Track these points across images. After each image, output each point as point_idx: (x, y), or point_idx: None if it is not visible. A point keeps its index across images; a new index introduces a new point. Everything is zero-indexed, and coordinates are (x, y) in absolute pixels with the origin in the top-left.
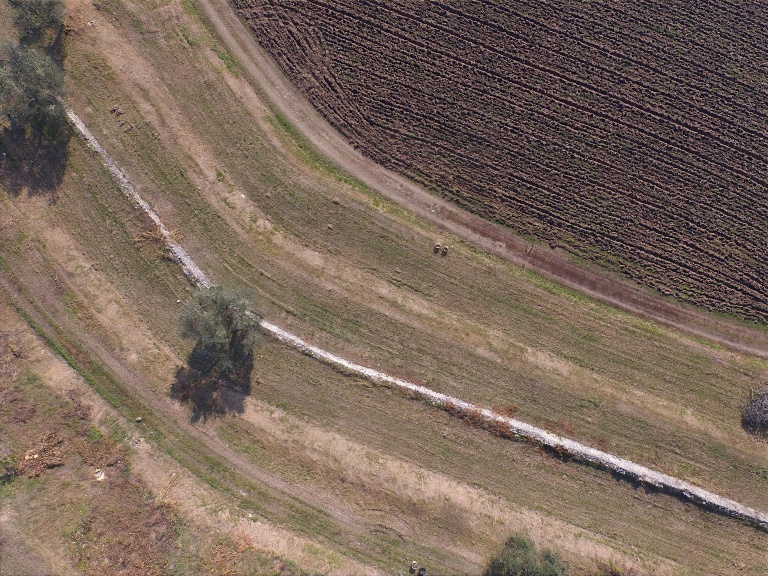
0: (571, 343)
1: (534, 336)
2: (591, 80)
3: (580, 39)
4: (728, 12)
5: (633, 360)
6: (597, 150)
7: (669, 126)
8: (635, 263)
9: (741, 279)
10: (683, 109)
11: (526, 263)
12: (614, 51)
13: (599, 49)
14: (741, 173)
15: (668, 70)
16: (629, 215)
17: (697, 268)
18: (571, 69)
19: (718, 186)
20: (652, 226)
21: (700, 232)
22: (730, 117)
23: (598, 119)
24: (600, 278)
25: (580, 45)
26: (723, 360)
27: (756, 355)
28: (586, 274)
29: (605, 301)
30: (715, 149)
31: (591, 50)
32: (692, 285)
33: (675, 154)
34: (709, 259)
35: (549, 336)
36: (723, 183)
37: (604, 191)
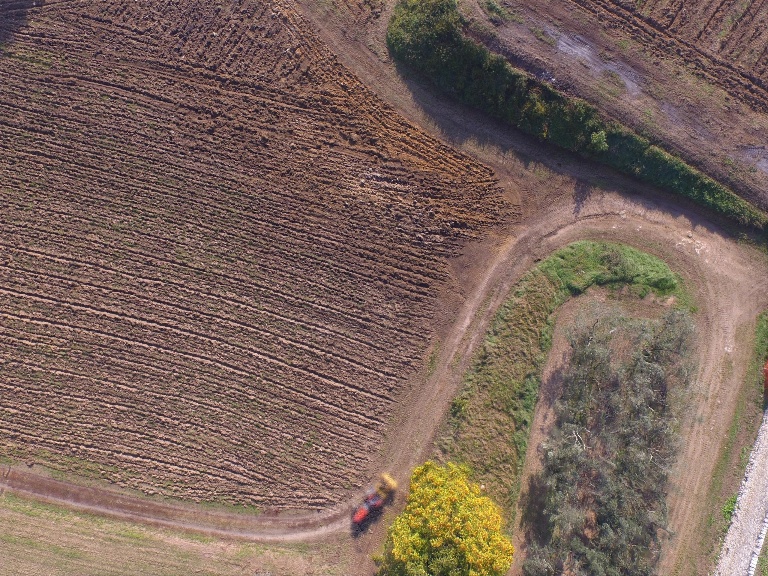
0: (53, 565)
1: (13, 565)
2: (42, 289)
3: (25, 249)
4: (171, 195)
5: (119, 571)
6: (58, 359)
7: (126, 323)
8: (115, 467)
9: (221, 466)
10: (138, 303)
11: (5, 487)
12: (61, 255)
13: (47, 255)
14: (205, 358)
15: (118, 265)
16: (101, 420)
17: (176, 462)
18: (20, 281)
19: (184, 375)
20: (125, 427)
21: (173, 425)
22: (185, 303)
23: (54, 328)
24: (83, 488)
25: (27, 255)
26: (212, 554)
27: (250, 540)
28: (68, 487)
29: (91, 511)
30: (175, 338)
31: (38, 258)
32: (175, 480)
33: (136, 350)
34: (187, 451)
35: (29, 562)
36: (188, 372)
37: (71, 400)
